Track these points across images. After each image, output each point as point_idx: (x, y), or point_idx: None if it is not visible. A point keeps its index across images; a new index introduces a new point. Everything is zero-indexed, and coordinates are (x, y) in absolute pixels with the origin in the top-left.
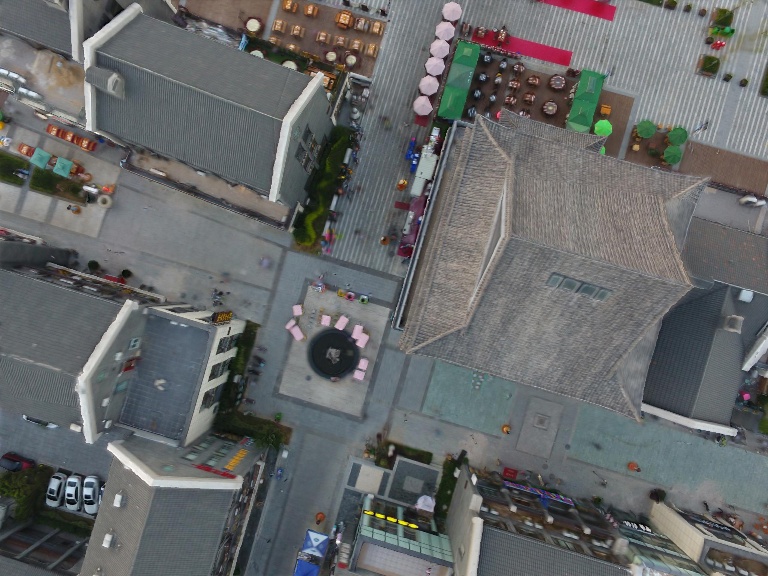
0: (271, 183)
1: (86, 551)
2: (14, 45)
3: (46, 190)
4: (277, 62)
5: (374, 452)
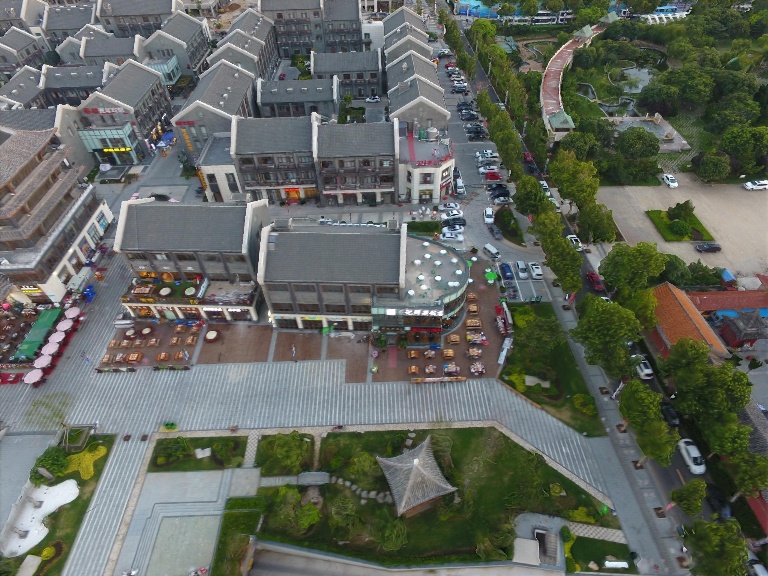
0: None
1: None
2: None
3: None
4: (177, 296)
5: None
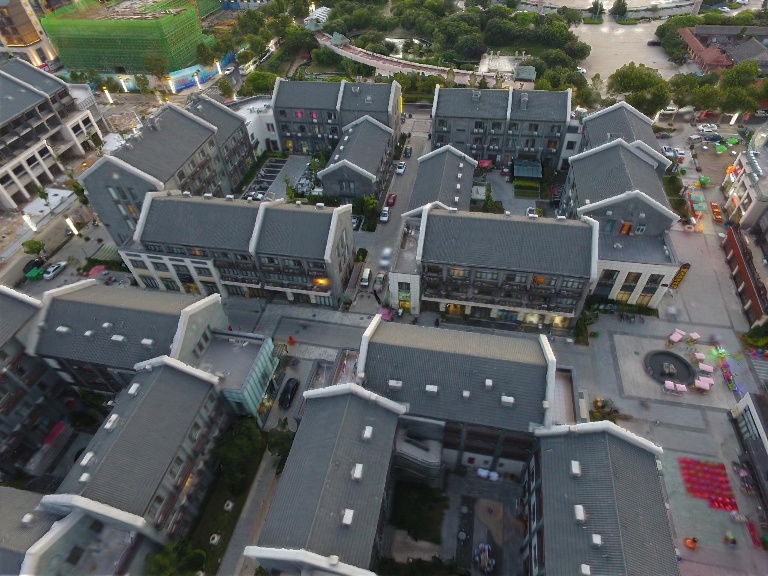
0: None
1: None
2: None
3: (674, 205)
4: None
5: (601, 408)
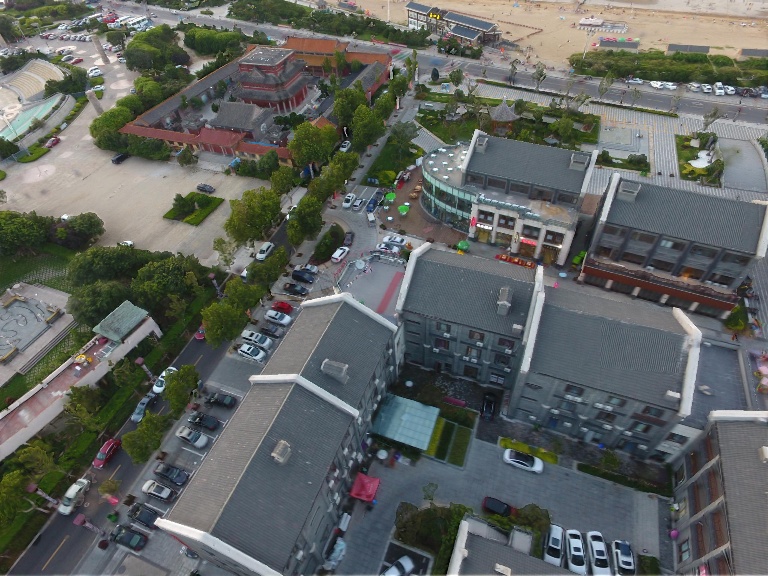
0: (756, 246)
1: (730, 533)
2: (515, 198)
3: None
4: None
5: None
